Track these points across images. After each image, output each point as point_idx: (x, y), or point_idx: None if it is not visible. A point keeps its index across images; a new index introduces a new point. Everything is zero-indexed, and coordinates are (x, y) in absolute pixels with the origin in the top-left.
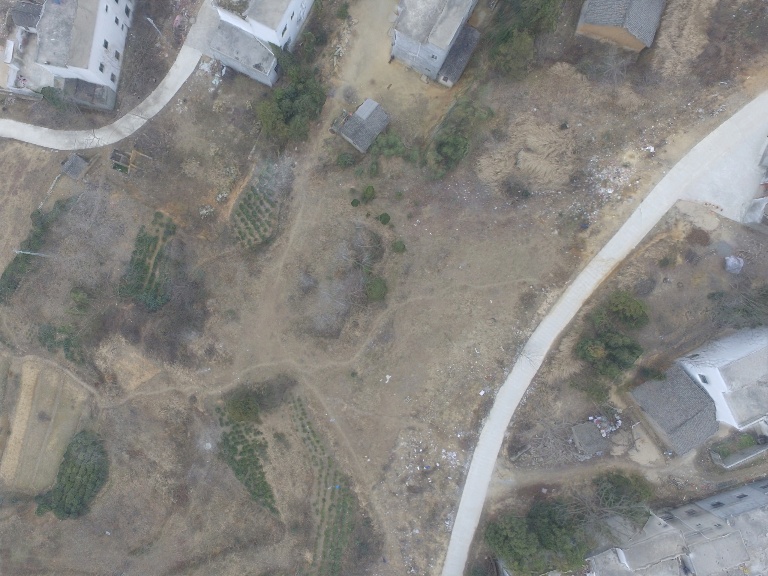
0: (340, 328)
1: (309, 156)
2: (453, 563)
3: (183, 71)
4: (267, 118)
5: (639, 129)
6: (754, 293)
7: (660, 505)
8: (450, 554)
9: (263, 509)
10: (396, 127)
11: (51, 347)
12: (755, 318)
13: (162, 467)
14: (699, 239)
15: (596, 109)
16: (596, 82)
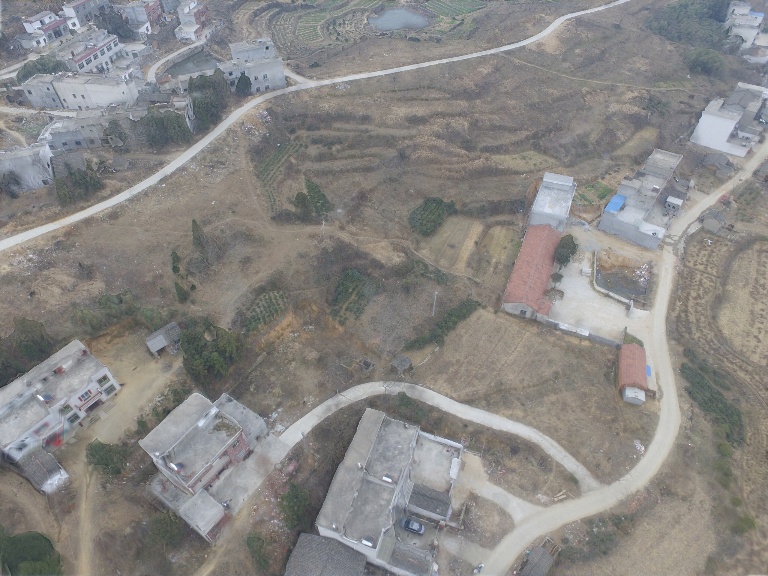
0: (235, 238)
1: None
2: None
3: (300, 427)
4: (228, 334)
5: None
6: None
7: None
8: (213, 138)
9: None
10: None
11: None
12: (4, 181)
13: None
14: (1, 223)
15: None
16: None
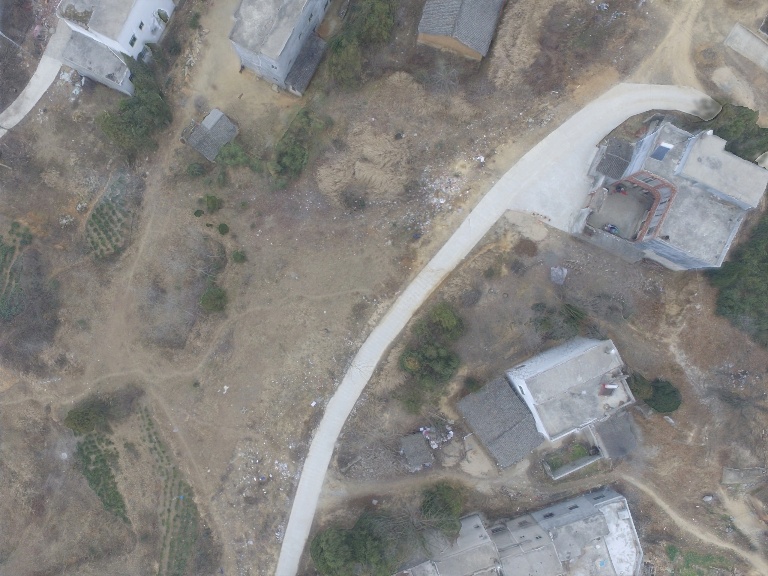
0: (187, 338)
1: (160, 166)
2: (284, 575)
3: (43, 81)
4: (107, 129)
5: (471, 139)
6: (578, 304)
7: (497, 516)
8: (280, 566)
9: (118, 519)
10: (248, 137)
11: None
12: (573, 329)
13: (23, 477)
14: (526, 249)
15: (431, 119)
16: (430, 92)
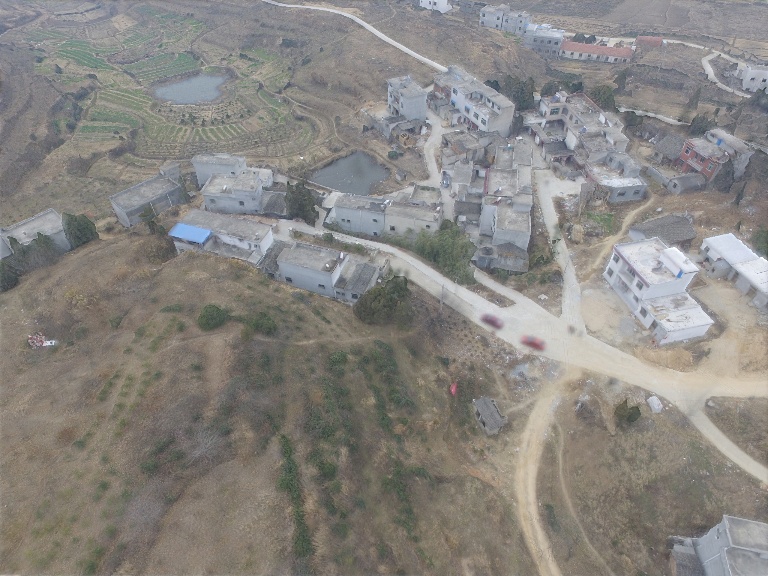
0: None
1: None
2: None
3: None
4: None
5: None
6: None
7: None
8: None
9: None
10: None
11: None
12: None
13: None
14: None
15: None
16: None
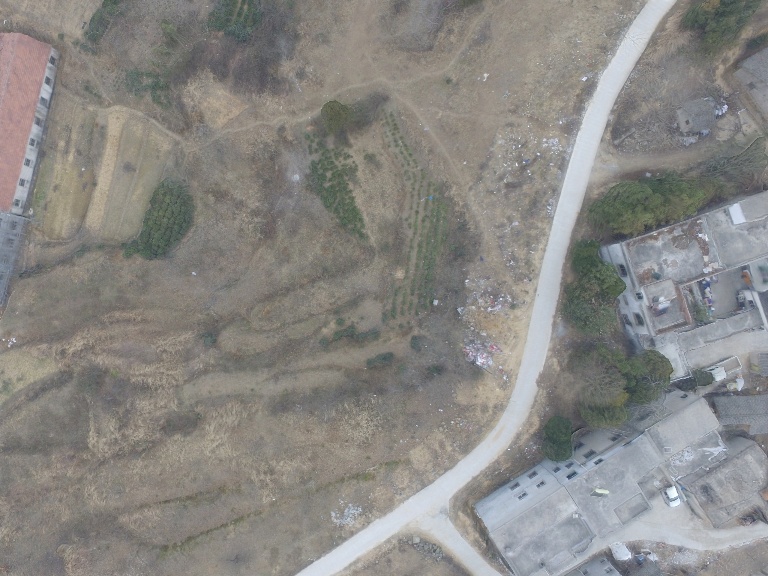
0: (433, 44)
1: None
2: (555, 248)
3: None
4: None
5: None
6: None
7: None
8: (552, 239)
9: (351, 239)
10: None
11: (138, 91)
12: None
13: (248, 207)
14: None
15: None
16: None
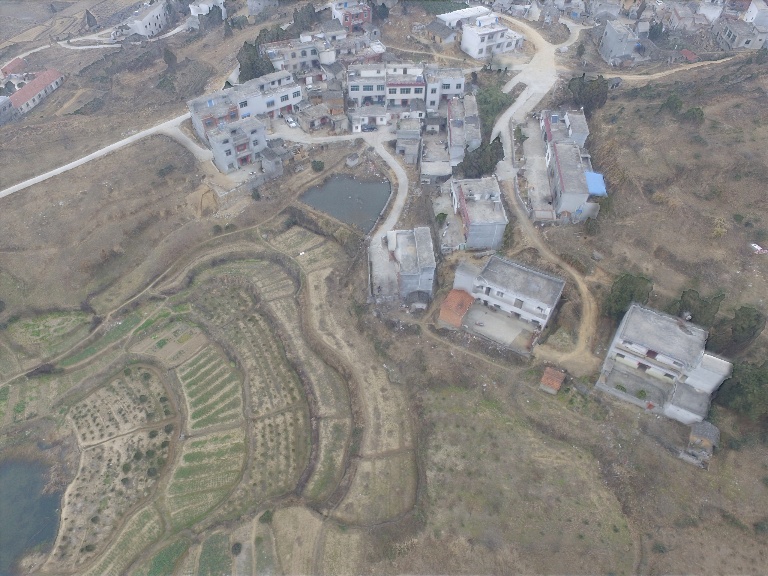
0: None
1: None
2: None
3: None
4: (200, 14)
5: (322, 1)
6: None
7: None
8: None
9: None
10: None
11: (95, 81)
12: None
13: None
14: None
15: None
16: None
